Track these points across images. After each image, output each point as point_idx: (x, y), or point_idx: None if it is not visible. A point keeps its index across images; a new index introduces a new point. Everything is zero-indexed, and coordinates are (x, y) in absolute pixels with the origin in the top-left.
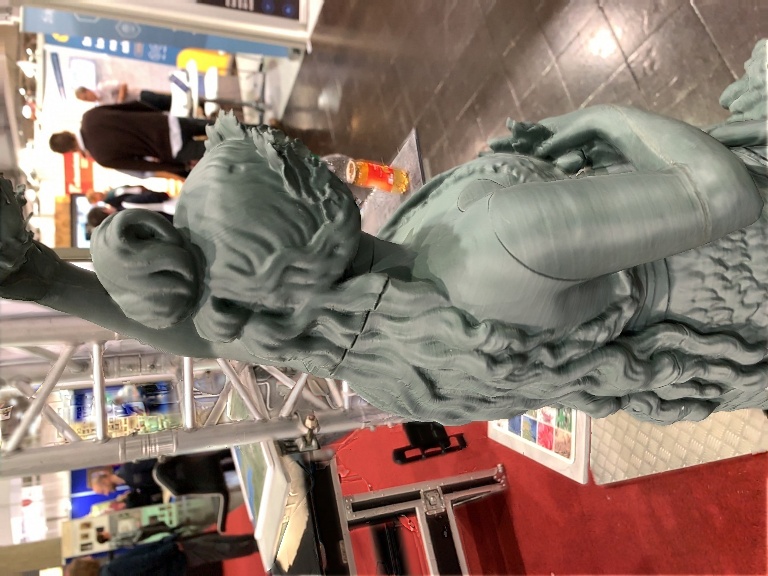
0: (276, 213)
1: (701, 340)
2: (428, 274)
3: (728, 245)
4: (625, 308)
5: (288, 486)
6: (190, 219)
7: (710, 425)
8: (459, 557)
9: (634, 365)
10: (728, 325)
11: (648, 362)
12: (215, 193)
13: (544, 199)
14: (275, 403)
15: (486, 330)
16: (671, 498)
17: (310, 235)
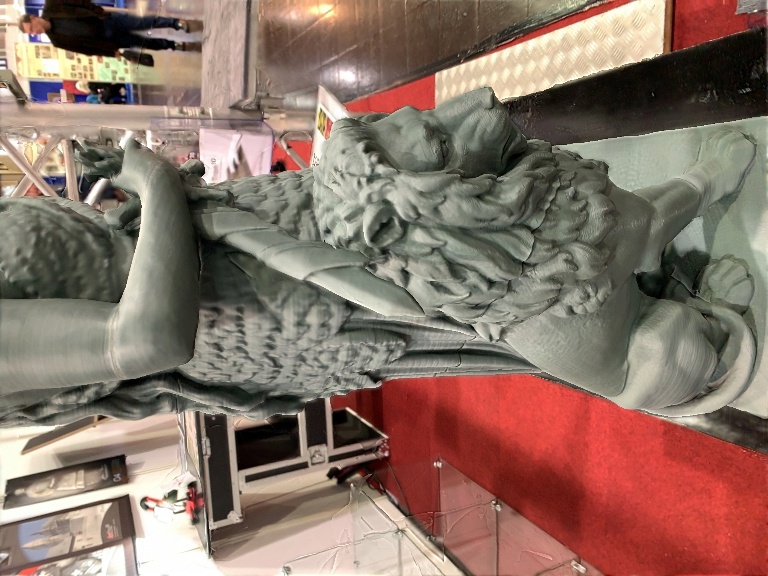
0: None
1: (195, 395)
2: None
3: (224, 335)
4: (106, 383)
5: None
6: None
7: None
8: None
9: (131, 409)
10: (228, 383)
11: (151, 403)
12: None
13: None
14: (85, 187)
15: None
16: None
17: None
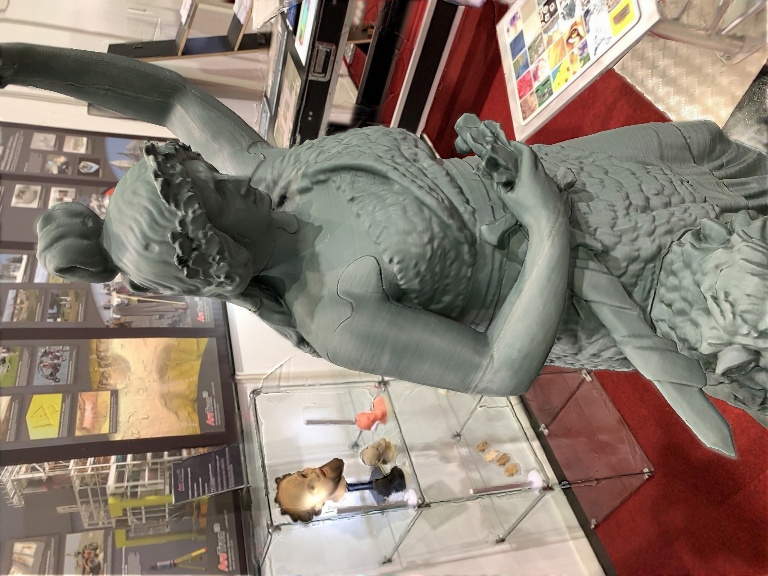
0: (178, 280)
1: None
2: (291, 308)
3: None
4: None
5: (280, 6)
6: (113, 255)
7: (705, 103)
8: (455, 19)
9: None
10: None
11: None
12: (132, 257)
13: (370, 351)
14: None
15: (309, 352)
16: (632, 114)
17: (205, 286)
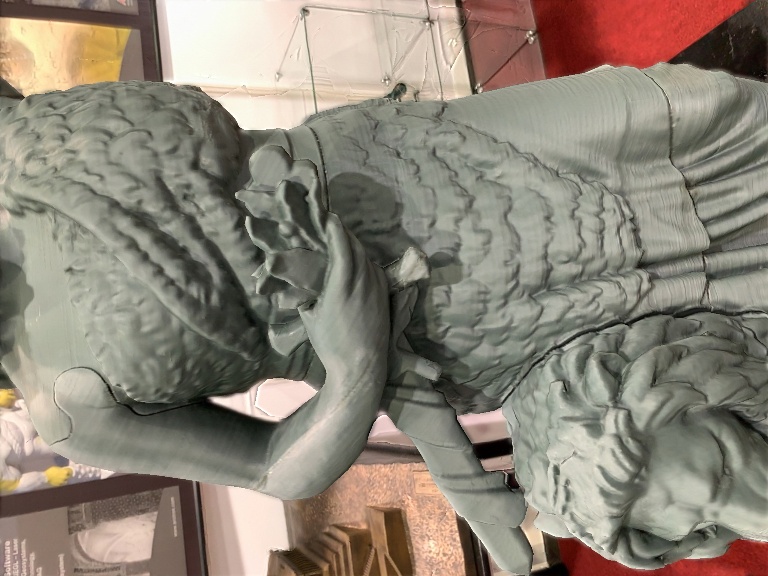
0: None
1: None
2: None
3: None
4: None
5: None
6: None
7: None
8: None
9: None
10: None
11: None
12: None
13: None
14: None
15: None
16: None
17: None
